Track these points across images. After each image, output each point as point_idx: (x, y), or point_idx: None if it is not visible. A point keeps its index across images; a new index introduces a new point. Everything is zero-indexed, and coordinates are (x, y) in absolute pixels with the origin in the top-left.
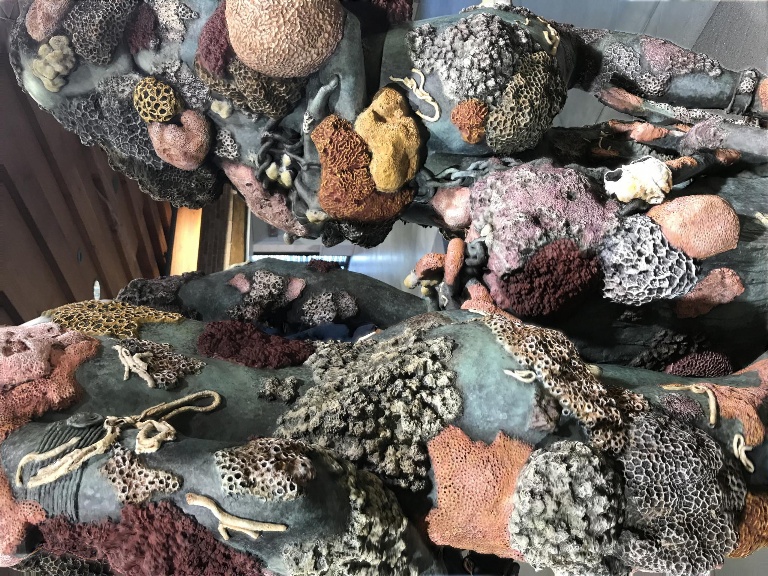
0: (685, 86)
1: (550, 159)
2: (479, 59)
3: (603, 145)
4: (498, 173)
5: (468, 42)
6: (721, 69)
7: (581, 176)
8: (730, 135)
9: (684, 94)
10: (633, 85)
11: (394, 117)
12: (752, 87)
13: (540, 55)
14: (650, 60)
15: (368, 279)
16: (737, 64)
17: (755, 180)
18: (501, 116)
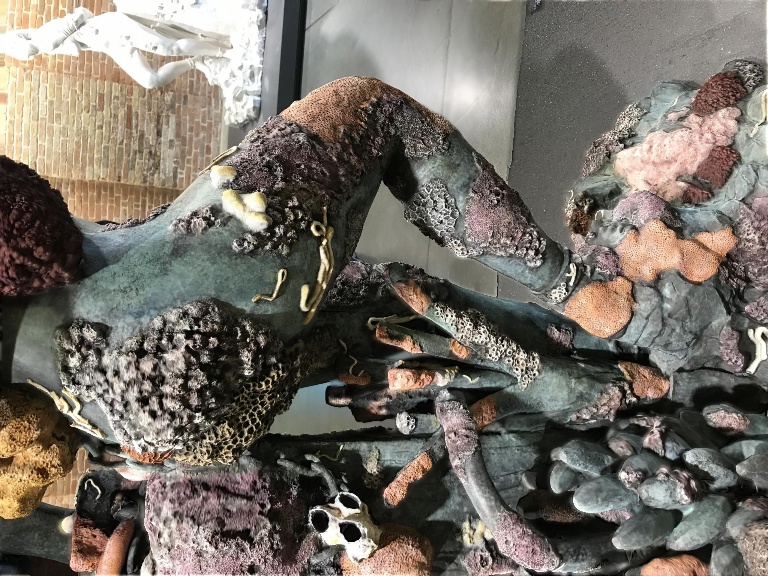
0: (495, 264)
1: (258, 466)
2: (156, 447)
3: (355, 369)
4: (182, 492)
5: (144, 419)
6: (544, 256)
7: (274, 541)
8: (467, 486)
9: (492, 267)
10: (439, 238)
11: (27, 452)
12: (561, 299)
13: (269, 384)
14: (468, 227)
15: (10, 520)
16: (645, 0)
17: (497, 440)
18: (192, 459)
